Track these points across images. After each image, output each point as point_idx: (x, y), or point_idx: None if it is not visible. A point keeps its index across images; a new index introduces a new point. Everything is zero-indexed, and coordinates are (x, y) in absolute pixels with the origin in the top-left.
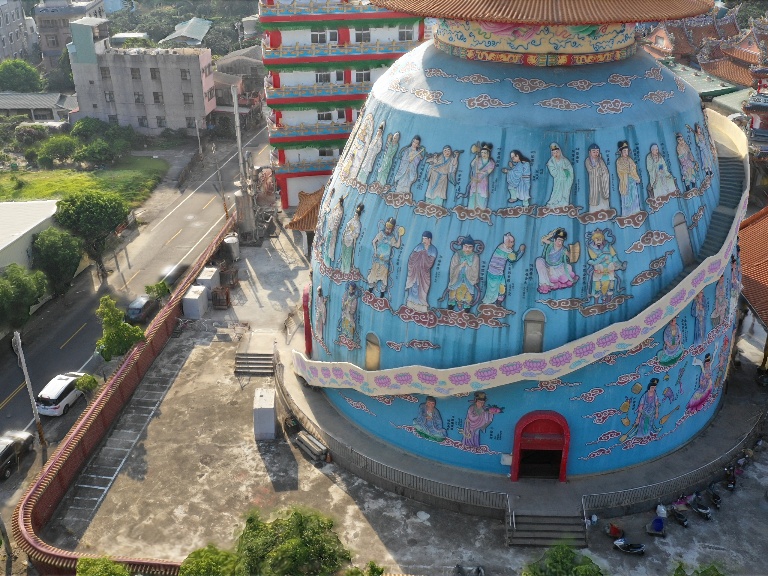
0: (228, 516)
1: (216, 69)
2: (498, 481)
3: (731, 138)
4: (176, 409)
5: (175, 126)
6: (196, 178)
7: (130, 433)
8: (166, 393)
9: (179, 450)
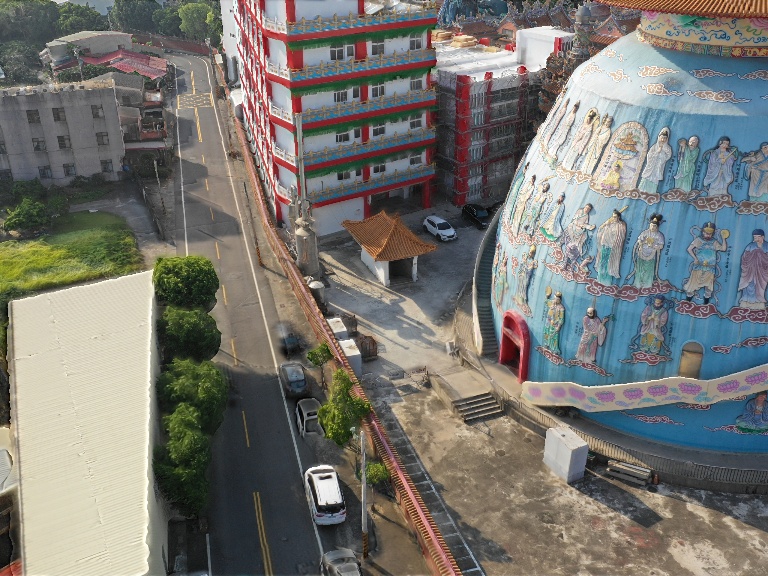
0: (635, 567)
1: None
2: None
3: None
4: (452, 476)
5: (87, 172)
6: (170, 226)
7: (437, 516)
8: (421, 463)
9: (508, 517)
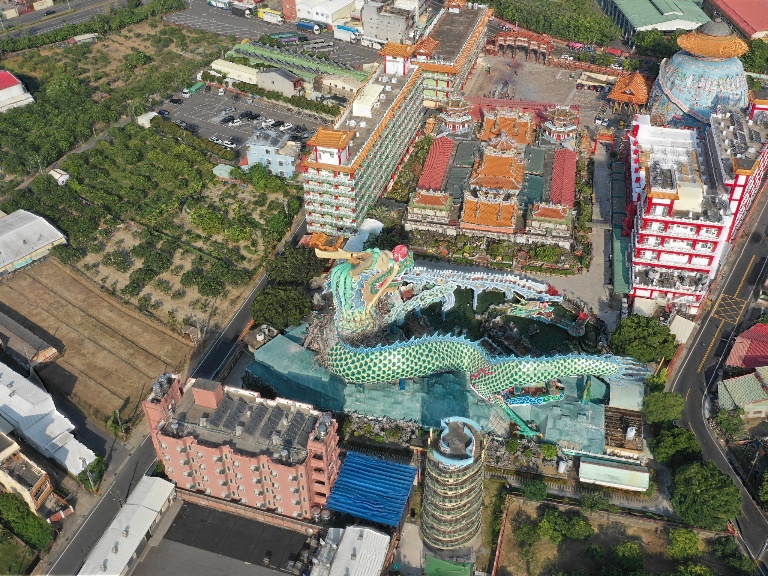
0: None
1: None
2: None
3: (662, 64)
4: None
5: None
6: None
7: None
8: None
9: None
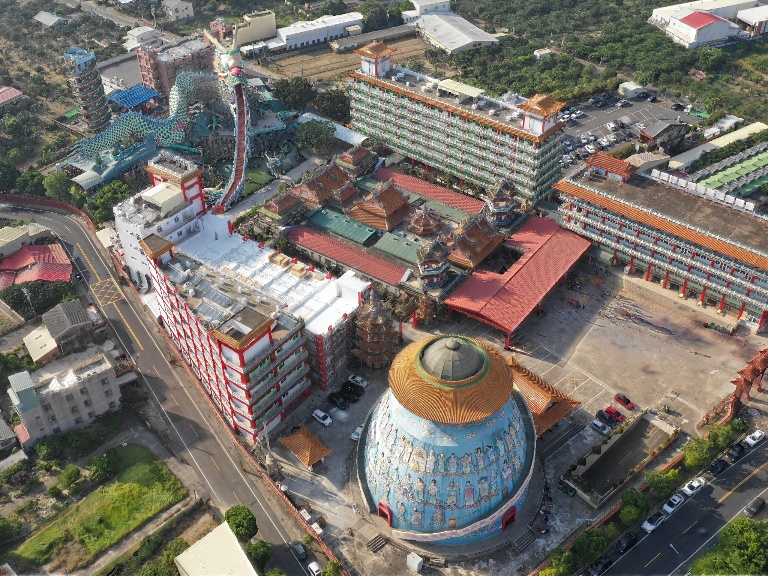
0: None
1: (1, 321)
2: (500, 535)
3: None
4: None
5: (102, 412)
6: (178, 449)
7: None
8: None
9: None
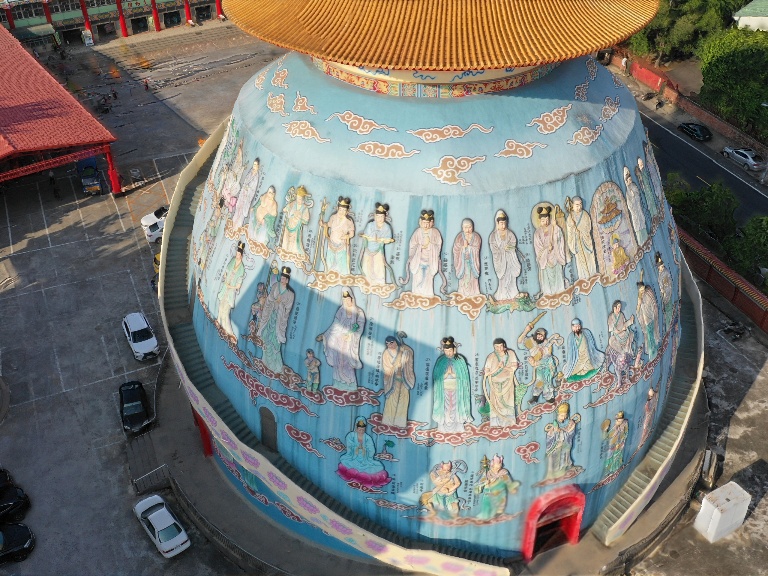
0: None
1: None
2: None
3: None
4: None
5: None
6: None
7: None
8: None
9: None
